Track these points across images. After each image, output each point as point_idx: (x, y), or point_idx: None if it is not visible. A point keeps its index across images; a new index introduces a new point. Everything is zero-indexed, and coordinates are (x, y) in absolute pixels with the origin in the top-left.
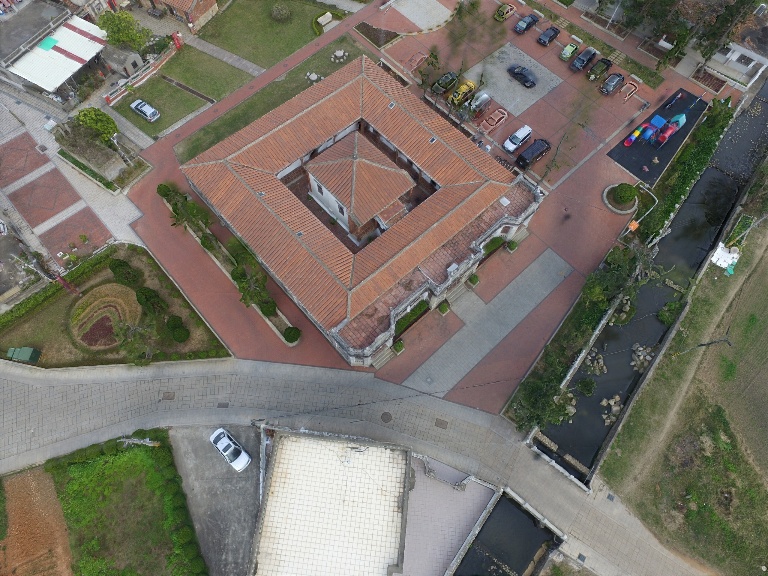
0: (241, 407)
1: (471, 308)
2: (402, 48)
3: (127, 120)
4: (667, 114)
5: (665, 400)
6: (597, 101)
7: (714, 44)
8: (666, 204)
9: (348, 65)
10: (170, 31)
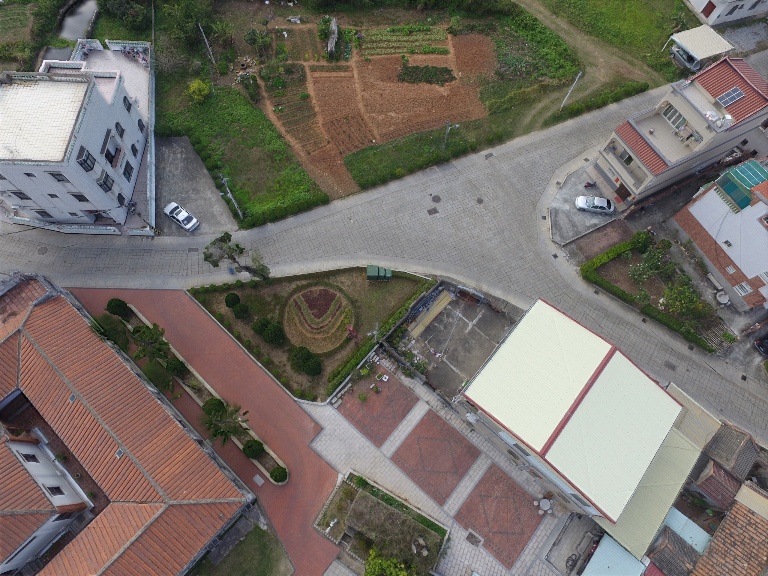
0: (177, 250)
1: None
2: None
3: None
4: None
5: None
6: None
7: None
8: None
9: None
10: None
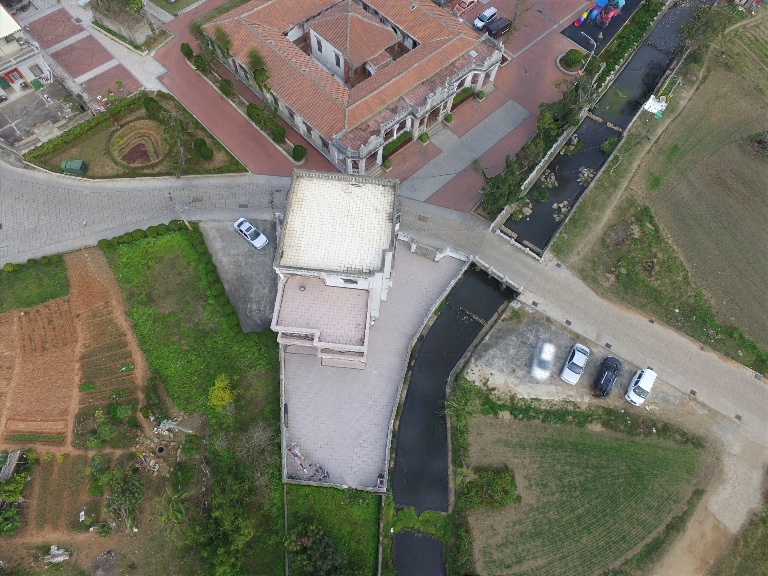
0: (258, 207)
1: (447, 140)
2: None
3: (150, 1)
4: None
5: (603, 202)
6: None
7: None
8: (608, 66)
9: None
10: None
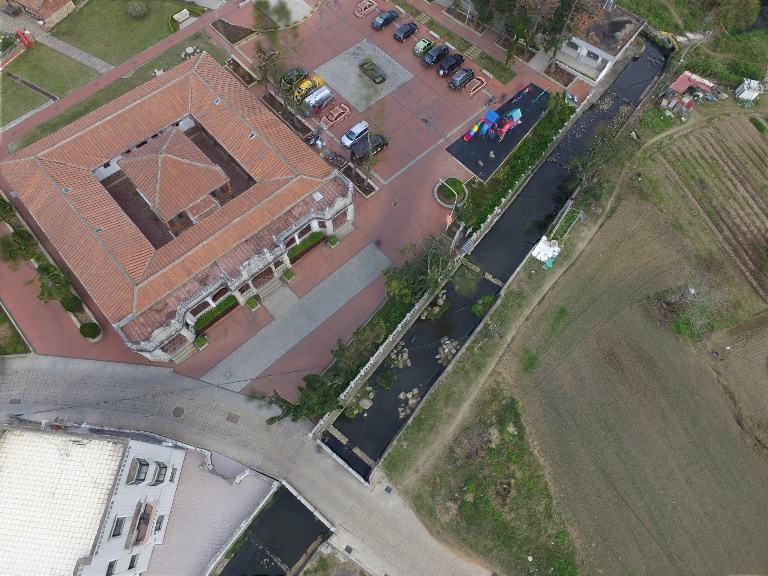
0: (33, 403)
1: (283, 303)
2: (256, 44)
3: None
4: (513, 109)
5: (460, 393)
6: (445, 96)
7: (555, 39)
8: (493, 198)
9: (186, 61)
10: (23, 29)
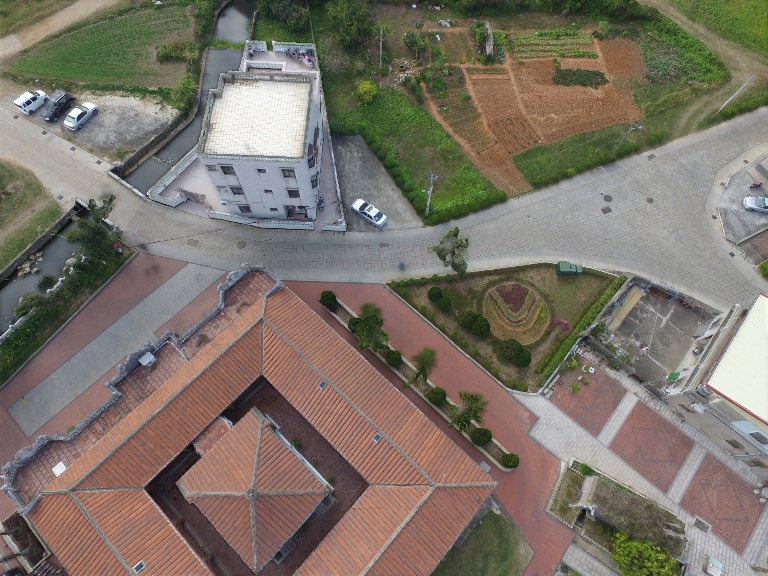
0: (368, 245)
1: None
2: None
3: None
4: None
5: None
6: None
7: None
8: None
9: None
10: None
